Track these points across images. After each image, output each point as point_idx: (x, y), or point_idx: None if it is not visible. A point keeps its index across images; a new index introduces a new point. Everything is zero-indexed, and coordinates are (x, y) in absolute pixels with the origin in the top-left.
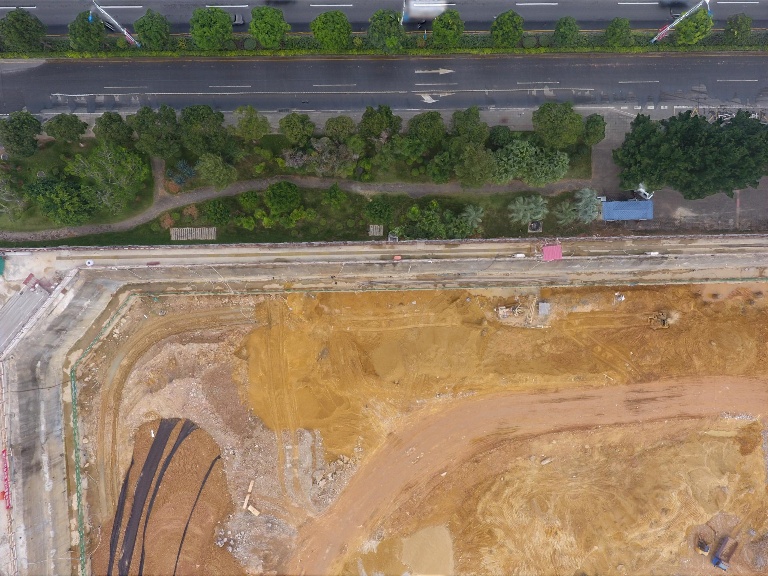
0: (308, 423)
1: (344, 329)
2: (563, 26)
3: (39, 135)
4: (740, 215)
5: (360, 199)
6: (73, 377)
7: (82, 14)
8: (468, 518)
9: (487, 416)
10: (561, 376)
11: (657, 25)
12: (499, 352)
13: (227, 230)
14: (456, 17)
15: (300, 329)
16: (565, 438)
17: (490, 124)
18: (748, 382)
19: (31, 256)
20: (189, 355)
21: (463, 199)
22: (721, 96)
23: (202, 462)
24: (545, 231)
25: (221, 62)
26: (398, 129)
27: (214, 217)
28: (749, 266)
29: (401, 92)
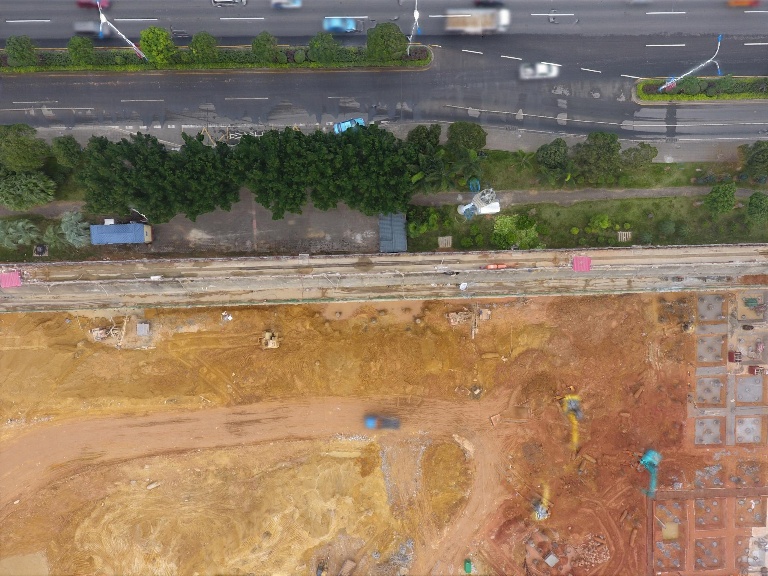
0: None
1: None
2: None
3: None
4: (258, 236)
5: None
6: None
7: None
8: (64, 545)
9: (67, 441)
10: (151, 399)
11: None
12: (93, 375)
13: None
14: None
15: None
16: (160, 462)
17: None
18: (361, 402)
19: None
20: None
21: None
22: (230, 115)
23: None
24: (52, 255)
25: None
26: None
27: None
28: (305, 287)
29: None
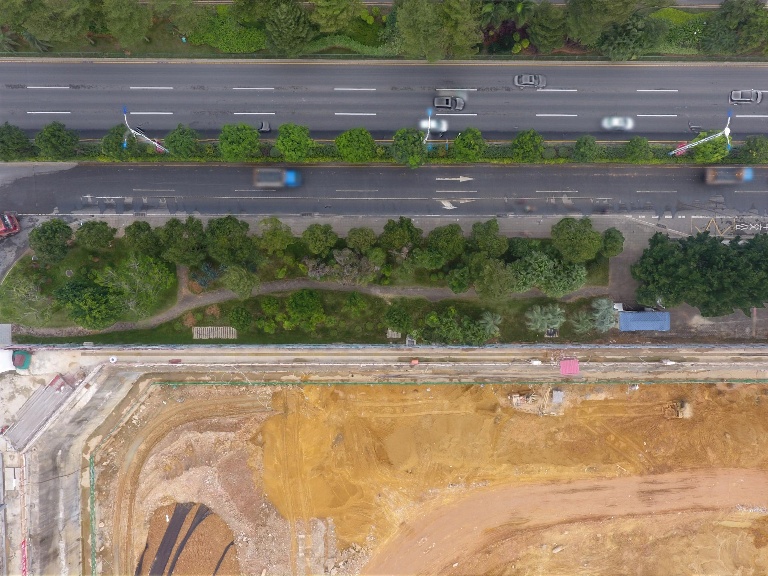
0: (321, 512)
1: (358, 414)
2: (583, 146)
3: (70, 240)
4: (757, 324)
5: (379, 302)
6: (92, 463)
7: (116, 130)
8: None
9: (499, 506)
10: (574, 467)
11: (675, 137)
12: (512, 440)
13: (248, 330)
14: (478, 137)
15: (315, 416)
16: (577, 529)
17: (509, 231)
18: (763, 475)
19: (57, 351)
20: (206, 443)
21: (481, 303)
22: (739, 207)
23: (215, 548)
24: (561, 336)
25: (247, 167)
26: (419, 242)
27: (237, 324)
28: None
29: (422, 199)
